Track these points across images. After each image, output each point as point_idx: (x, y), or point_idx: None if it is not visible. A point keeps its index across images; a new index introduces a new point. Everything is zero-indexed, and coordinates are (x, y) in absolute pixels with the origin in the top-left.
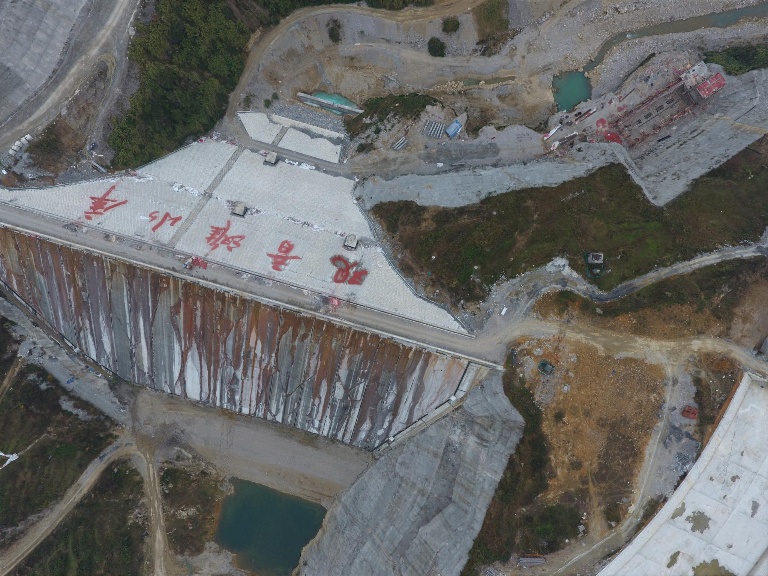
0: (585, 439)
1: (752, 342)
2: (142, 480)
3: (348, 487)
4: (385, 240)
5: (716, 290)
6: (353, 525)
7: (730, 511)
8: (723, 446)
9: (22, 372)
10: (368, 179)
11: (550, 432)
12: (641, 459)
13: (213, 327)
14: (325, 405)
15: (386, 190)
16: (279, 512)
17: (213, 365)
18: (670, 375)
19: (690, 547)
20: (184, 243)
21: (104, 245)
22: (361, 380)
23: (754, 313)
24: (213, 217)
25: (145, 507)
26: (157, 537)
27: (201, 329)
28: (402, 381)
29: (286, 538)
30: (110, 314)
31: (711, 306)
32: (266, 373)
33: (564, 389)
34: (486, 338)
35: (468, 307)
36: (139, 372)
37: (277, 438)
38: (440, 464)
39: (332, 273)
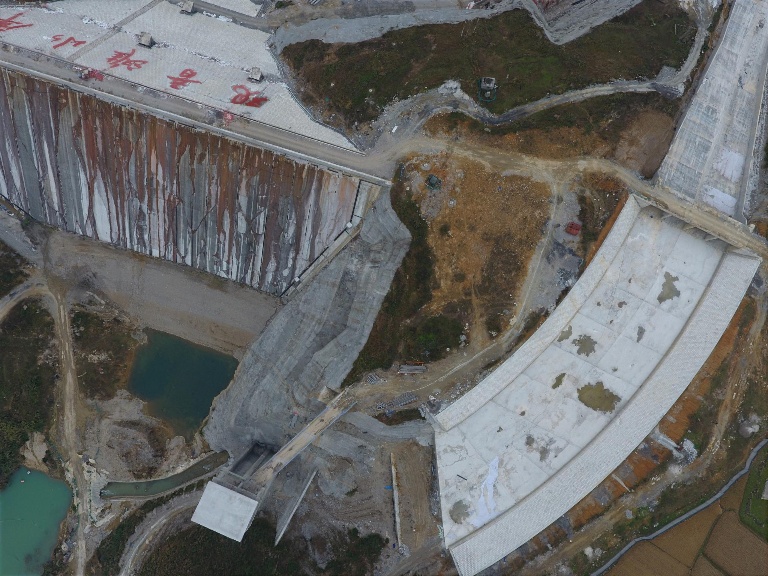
0: (469, 252)
1: (637, 164)
2: (53, 321)
3: (258, 335)
4: (291, 77)
5: (604, 115)
6: (256, 363)
7: (616, 336)
8: (611, 273)
9: None
10: (280, 26)
11: (435, 244)
12: (524, 273)
13: (114, 150)
14: (230, 242)
15: (296, 33)
16: (192, 364)
17: (119, 198)
18: (555, 193)
19: (575, 369)
20: (83, 60)
21: (2, 55)
22: (261, 208)
23: (641, 137)
24: (118, 45)
25: (56, 349)
26: (68, 380)
27: (103, 153)
28: (300, 207)
29: (198, 390)
30: (15, 139)
31: (599, 129)
32: (170, 205)
33: (450, 203)
34: (376, 155)
35: (361, 128)
36: (50, 210)
37: (186, 281)
38: (337, 292)
39: (231, 96)
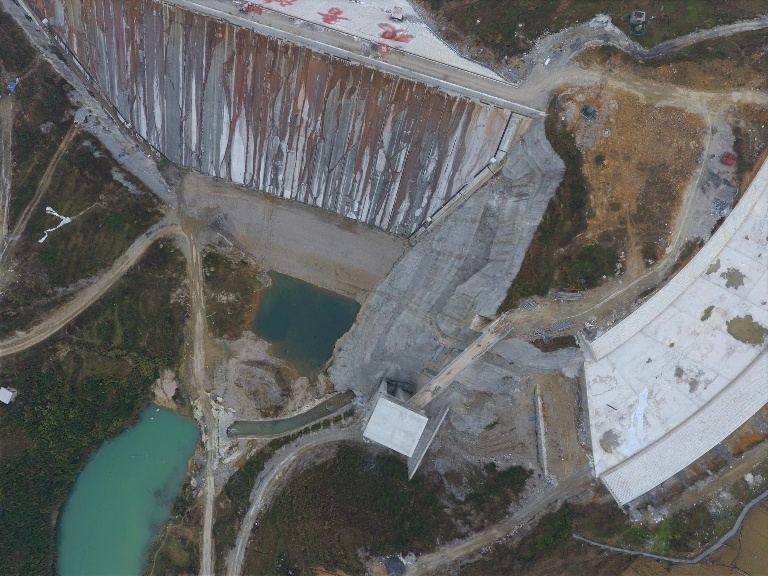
0: (624, 182)
1: None
2: (185, 261)
3: (383, 278)
4: (429, 17)
5: (757, 48)
6: (389, 301)
7: (765, 269)
8: (759, 207)
9: (78, 137)
10: None
11: (590, 174)
12: (679, 203)
13: (263, 86)
14: (366, 181)
15: None
16: (314, 307)
17: (260, 136)
18: (709, 124)
19: (724, 302)
20: None
21: None
22: (403, 145)
23: None
24: None
25: (187, 289)
26: (197, 319)
27: (251, 90)
28: (444, 143)
29: (320, 332)
30: (164, 77)
31: (751, 62)
32: (311, 143)
33: (605, 134)
34: (529, 87)
35: (512, 62)
36: (187, 151)
37: (317, 222)
38: (478, 228)
39: (380, 32)
